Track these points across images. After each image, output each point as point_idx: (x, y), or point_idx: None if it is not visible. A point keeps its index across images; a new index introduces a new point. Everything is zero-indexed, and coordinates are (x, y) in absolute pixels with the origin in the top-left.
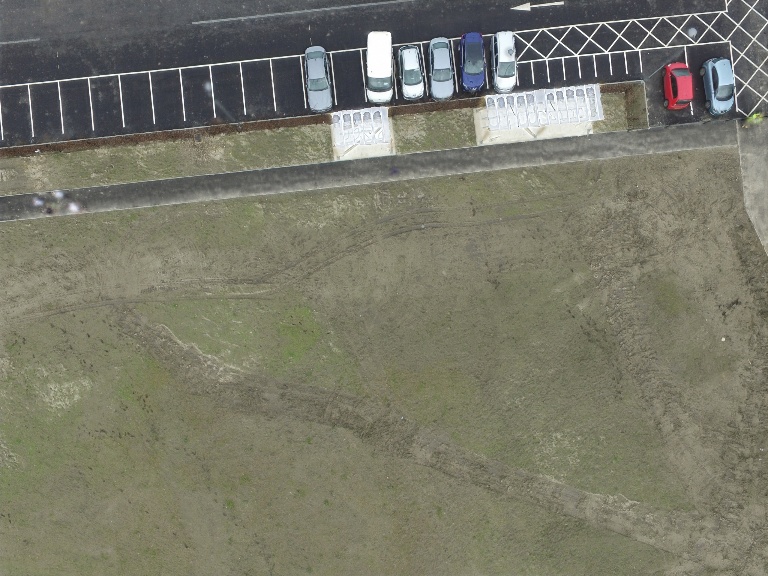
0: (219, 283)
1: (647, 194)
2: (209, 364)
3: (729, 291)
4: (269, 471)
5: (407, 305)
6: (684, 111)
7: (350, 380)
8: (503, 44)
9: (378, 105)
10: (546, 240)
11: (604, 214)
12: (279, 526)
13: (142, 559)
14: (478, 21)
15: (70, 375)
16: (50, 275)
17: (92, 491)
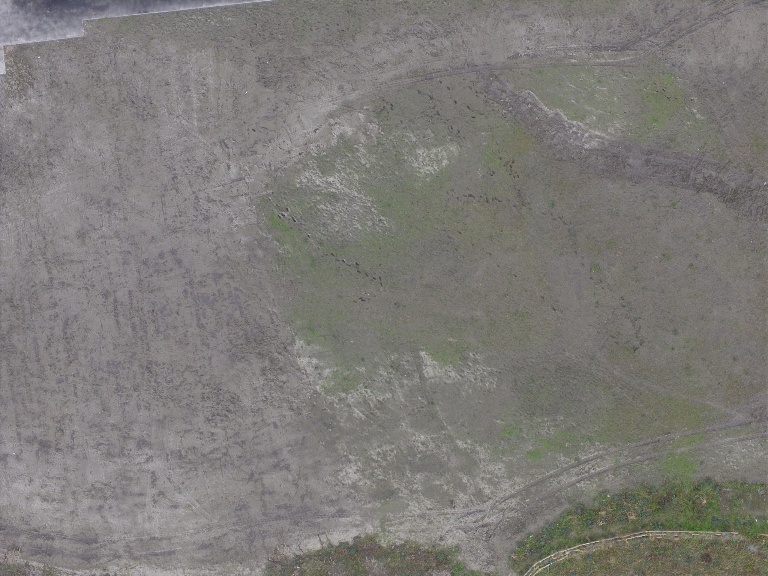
0: (583, 50)
1: None
2: (574, 131)
3: None
4: (635, 235)
5: None
6: None
7: (713, 146)
8: None
9: None
10: None
11: None
12: (645, 289)
13: (511, 322)
14: None
15: (438, 140)
16: (416, 42)
17: (461, 255)
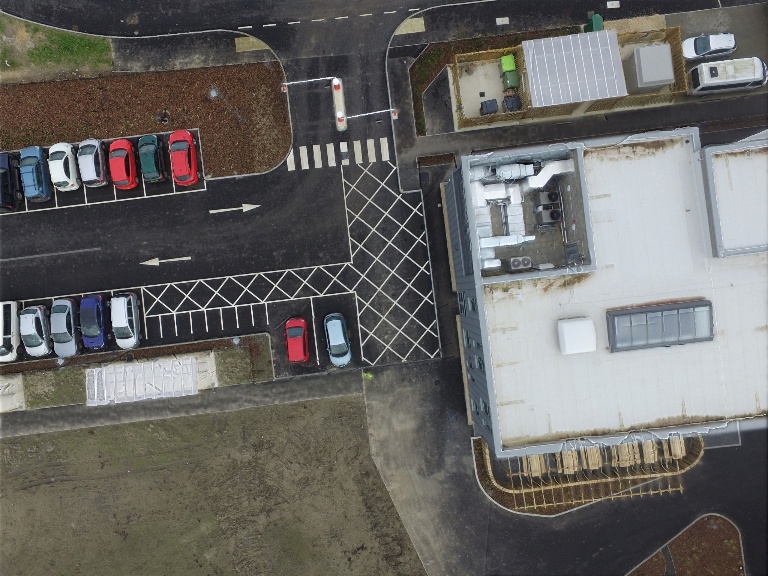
0: None
1: (273, 444)
2: None
3: (354, 537)
4: None
5: (36, 558)
6: (310, 361)
7: None
8: (115, 310)
9: (6, 362)
10: (173, 492)
11: (230, 465)
12: None
13: None
14: (108, 276)
15: None
16: None
17: None
